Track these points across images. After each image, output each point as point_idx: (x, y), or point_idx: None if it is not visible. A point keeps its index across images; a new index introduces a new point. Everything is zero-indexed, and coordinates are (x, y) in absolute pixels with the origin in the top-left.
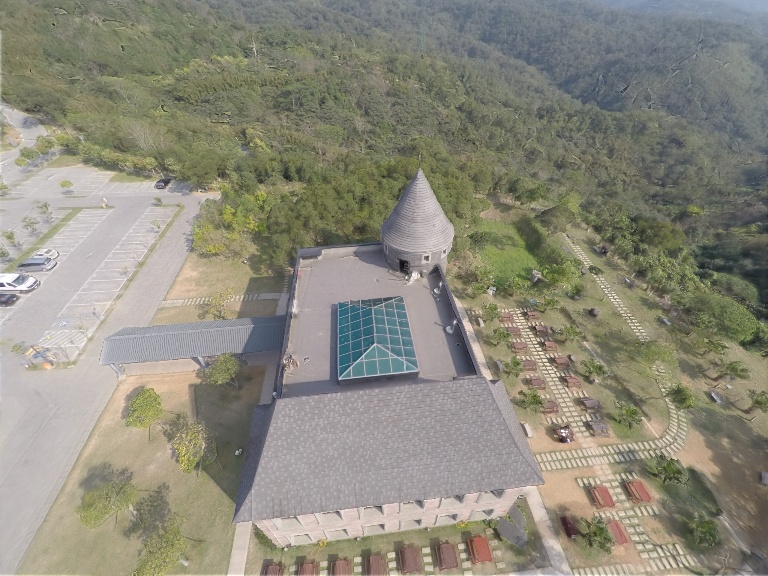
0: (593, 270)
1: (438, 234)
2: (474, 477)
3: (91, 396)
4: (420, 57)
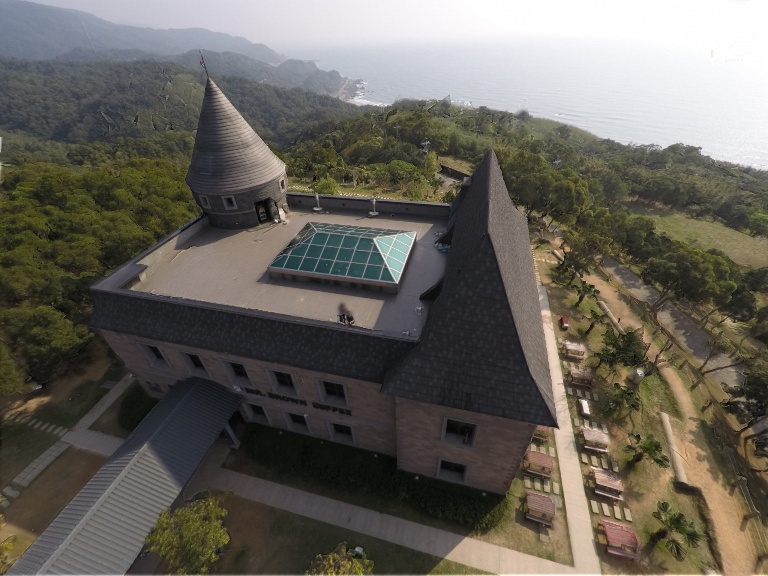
0: None
1: (273, 154)
2: (523, 236)
3: None
4: None
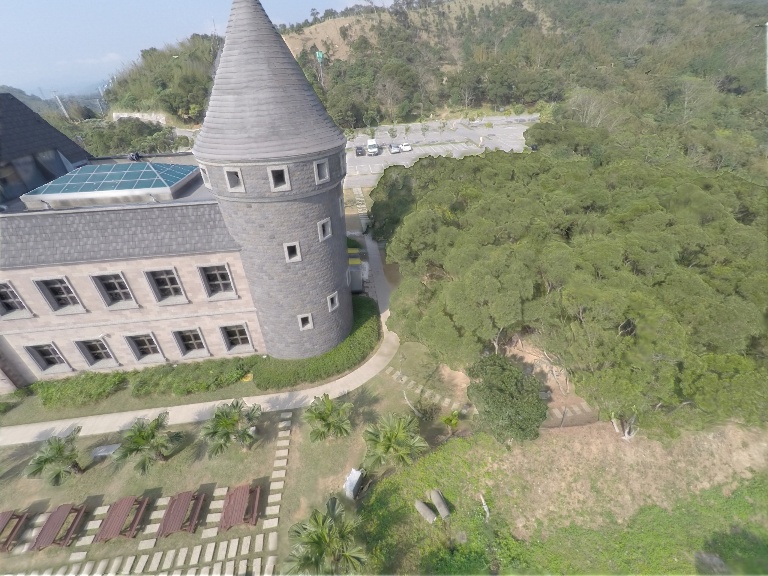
0: None
1: (205, 128)
2: None
3: None
4: None
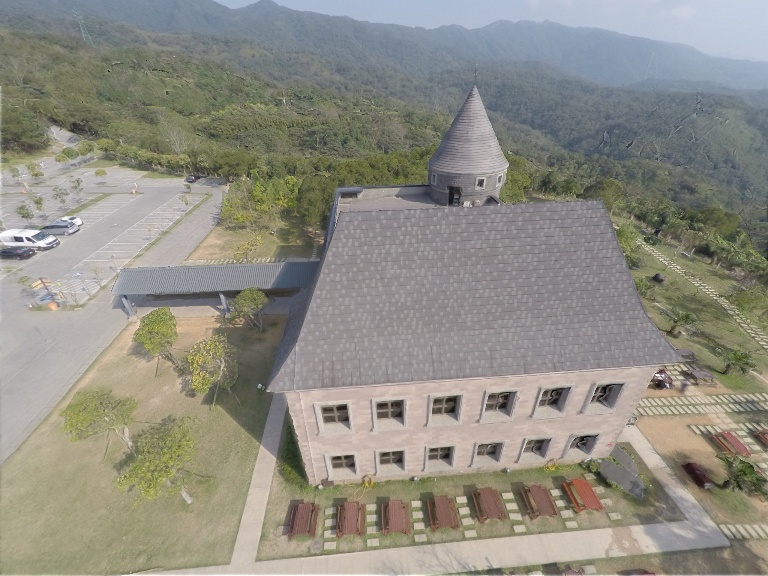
0: (650, 240)
1: (494, 156)
2: (589, 347)
3: (96, 334)
4: (434, 115)
